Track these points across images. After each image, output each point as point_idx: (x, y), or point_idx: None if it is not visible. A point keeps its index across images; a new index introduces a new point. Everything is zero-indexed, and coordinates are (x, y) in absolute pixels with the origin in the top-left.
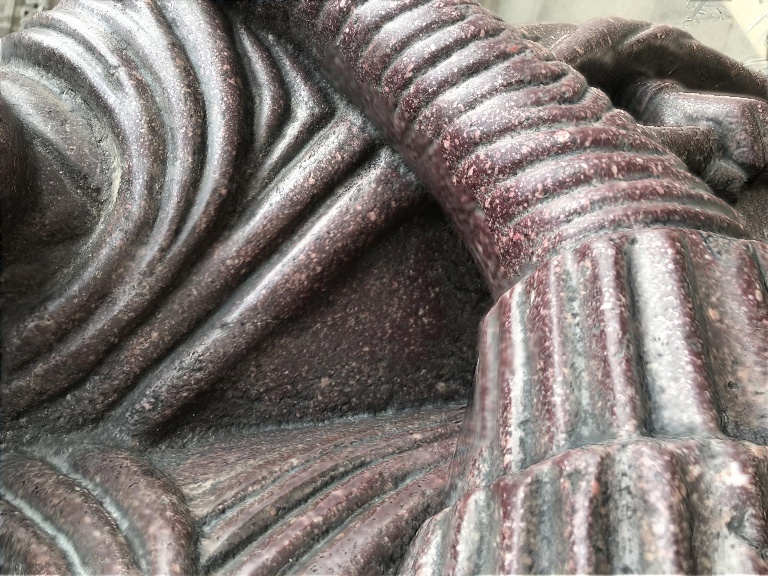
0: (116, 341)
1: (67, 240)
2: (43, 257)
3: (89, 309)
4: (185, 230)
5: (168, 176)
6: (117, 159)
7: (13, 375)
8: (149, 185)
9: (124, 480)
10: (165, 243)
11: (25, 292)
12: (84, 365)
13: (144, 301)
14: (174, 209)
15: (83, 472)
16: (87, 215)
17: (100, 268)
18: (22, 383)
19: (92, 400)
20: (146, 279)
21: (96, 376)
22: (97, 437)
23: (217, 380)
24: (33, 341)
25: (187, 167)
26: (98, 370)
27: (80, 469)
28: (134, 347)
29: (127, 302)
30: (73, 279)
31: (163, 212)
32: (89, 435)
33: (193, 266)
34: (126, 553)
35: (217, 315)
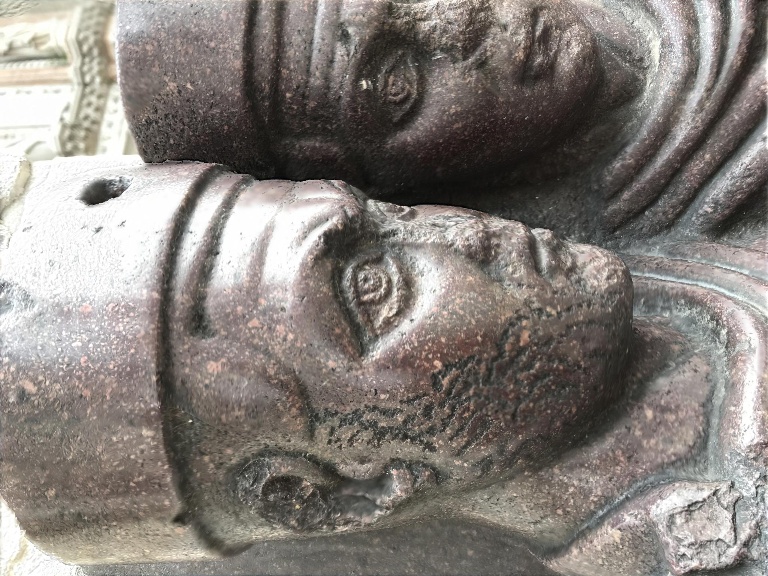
0: (678, 166)
1: (625, 102)
2: (612, 118)
3: (656, 147)
4: (724, 70)
5: (701, 32)
6: (653, 32)
7: (607, 203)
8: (688, 43)
9: (725, 252)
10: (709, 84)
11: (603, 146)
12: (657, 188)
13: (698, 132)
14: (713, 56)
15: (681, 255)
16: (637, 80)
17: (661, 115)
18: (615, 207)
19: (665, 212)
20: (698, 115)
21: (665, 195)
22: (673, 238)
23: (764, 182)
24: (620, 176)
25: (718, 20)
26: (666, 190)
27: (677, 255)
28: (692, 169)
29: (685, 135)
30: (641, 127)
31: (703, 61)
32: (666, 237)
33: (732, 97)
34: (764, 282)
35: (756, 132)
